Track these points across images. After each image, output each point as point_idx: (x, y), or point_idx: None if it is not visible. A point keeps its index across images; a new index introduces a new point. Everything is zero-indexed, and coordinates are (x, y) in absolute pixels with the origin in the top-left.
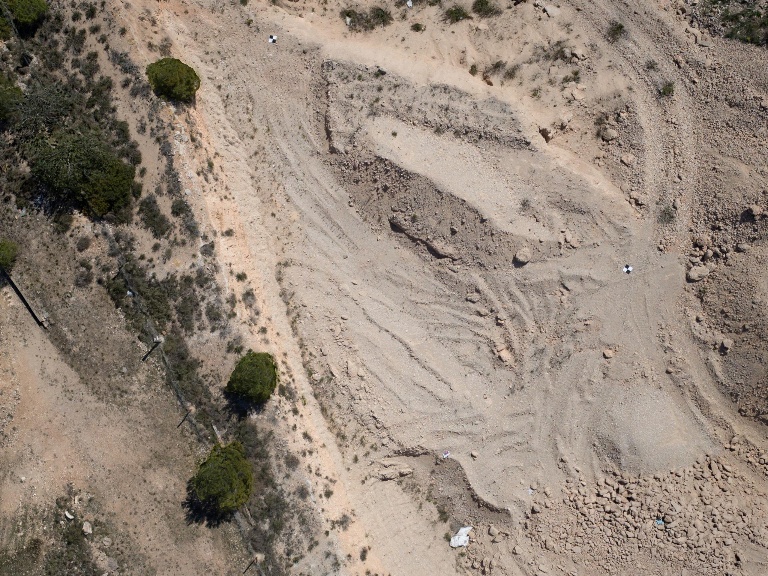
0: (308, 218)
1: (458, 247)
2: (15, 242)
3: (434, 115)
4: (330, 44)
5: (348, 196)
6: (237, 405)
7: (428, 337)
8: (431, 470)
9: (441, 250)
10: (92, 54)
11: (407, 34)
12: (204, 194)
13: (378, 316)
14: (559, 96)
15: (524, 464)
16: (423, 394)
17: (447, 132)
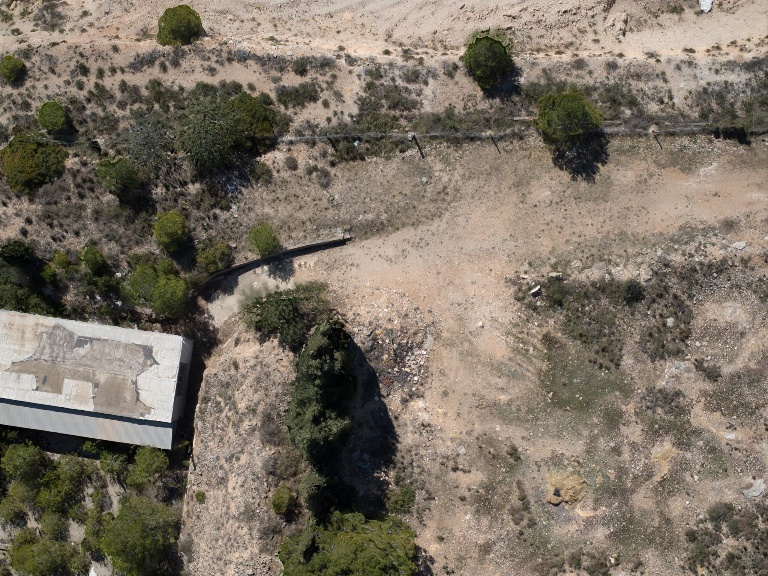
0: (356, 5)
1: None
2: None
3: None
4: None
5: None
6: (505, 91)
7: None
8: None
9: None
10: (121, 86)
11: None
12: None
13: None
14: None
15: None
16: None
17: None
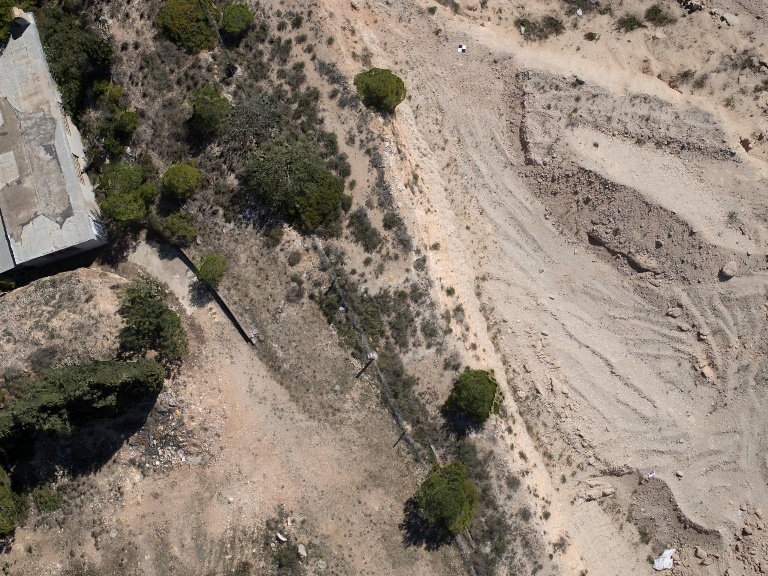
0: (503, 231)
1: (662, 261)
2: (223, 256)
3: (634, 125)
4: (521, 53)
5: (544, 208)
6: (455, 424)
7: (627, 353)
8: (633, 490)
9: (644, 264)
10: (298, 64)
11: (581, 43)
12: (413, 207)
13: (577, 331)
14: (754, 106)
15: (731, 484)
16: (627, 412)
17: (648, 143)
